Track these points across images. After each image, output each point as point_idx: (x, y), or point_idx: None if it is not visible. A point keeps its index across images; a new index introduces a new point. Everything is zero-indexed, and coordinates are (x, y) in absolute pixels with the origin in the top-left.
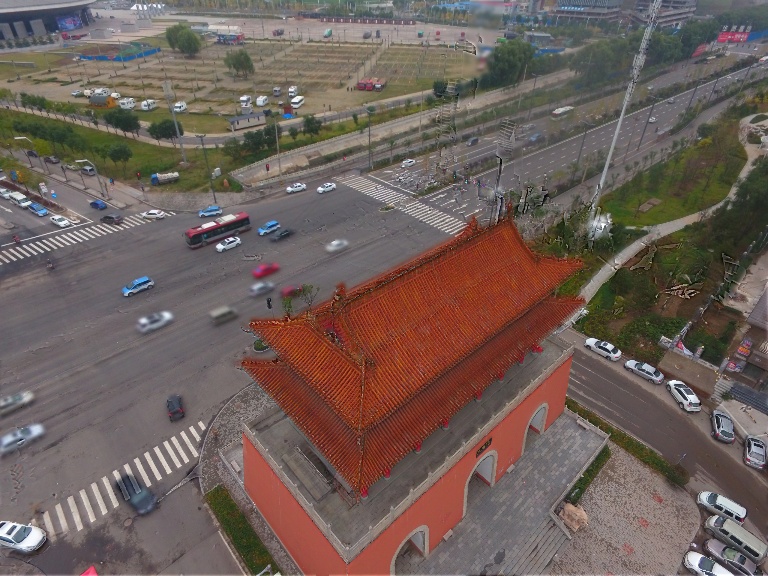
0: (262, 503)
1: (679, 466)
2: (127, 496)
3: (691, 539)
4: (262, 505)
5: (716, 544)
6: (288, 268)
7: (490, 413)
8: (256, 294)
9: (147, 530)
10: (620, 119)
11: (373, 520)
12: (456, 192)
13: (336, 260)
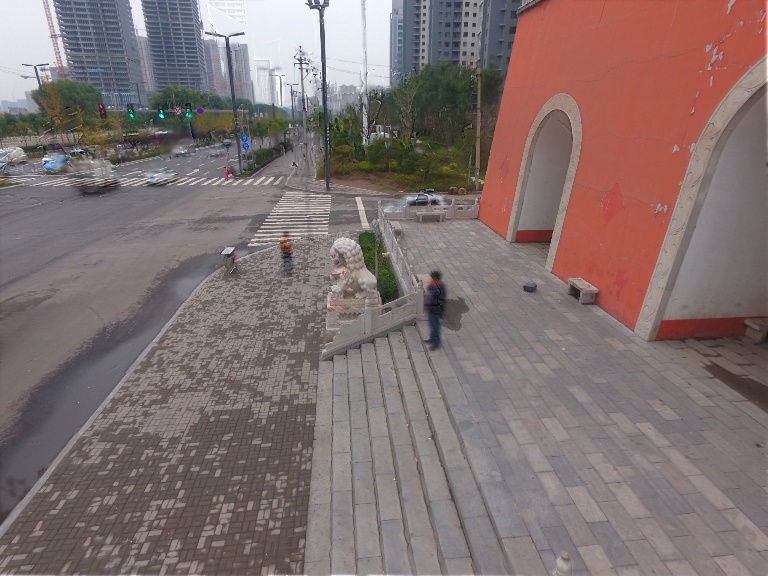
0: None
1: None
2: None
3: None
4: None
5: None
6: None
7: None
8: None
9: None
10: None
11: None
12: None
13: None
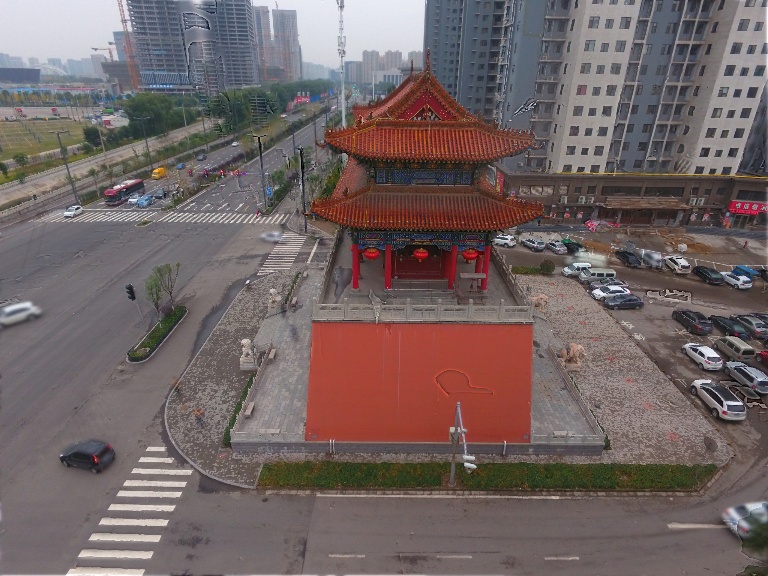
0: (350, 422)
1: (546, 260)
2: (136, 572)
3: (584, 290)
4: (350, 425)
5: (596, 283)
6: (78, 293)
7: None
8: (60, 326)
9: (223, 568)
10: (341, 89)
11: (506, 300)
12: (204, 199)
13: (137, 269)
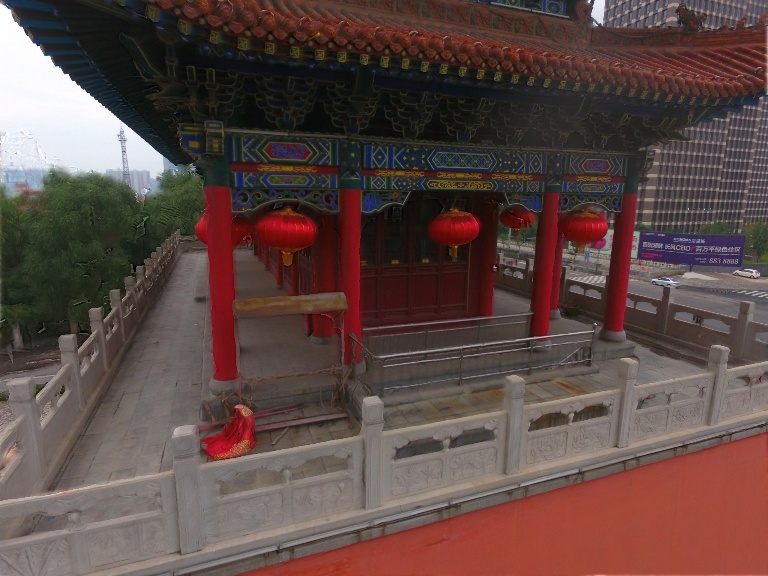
0: None
1: None
2: None
3: None
4: None
5: None
6: None
7: (176, 301)
8: None
9: None
10: None
11: None
12: None
13: None
